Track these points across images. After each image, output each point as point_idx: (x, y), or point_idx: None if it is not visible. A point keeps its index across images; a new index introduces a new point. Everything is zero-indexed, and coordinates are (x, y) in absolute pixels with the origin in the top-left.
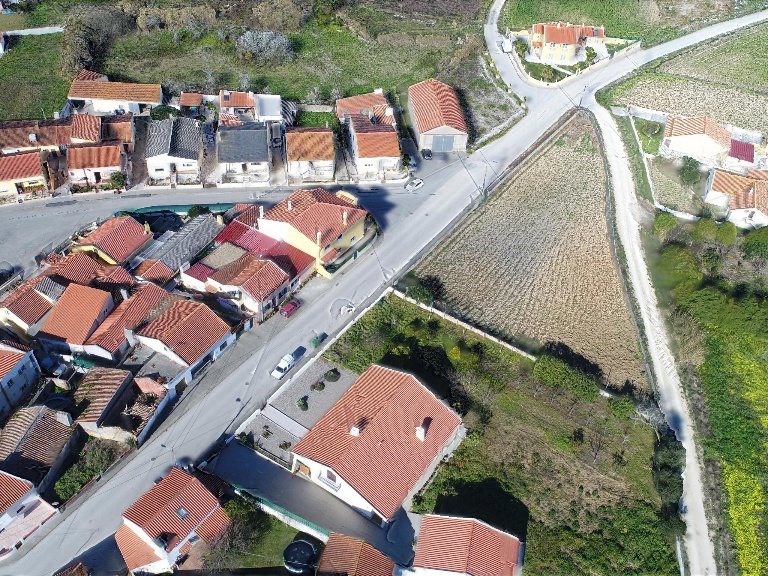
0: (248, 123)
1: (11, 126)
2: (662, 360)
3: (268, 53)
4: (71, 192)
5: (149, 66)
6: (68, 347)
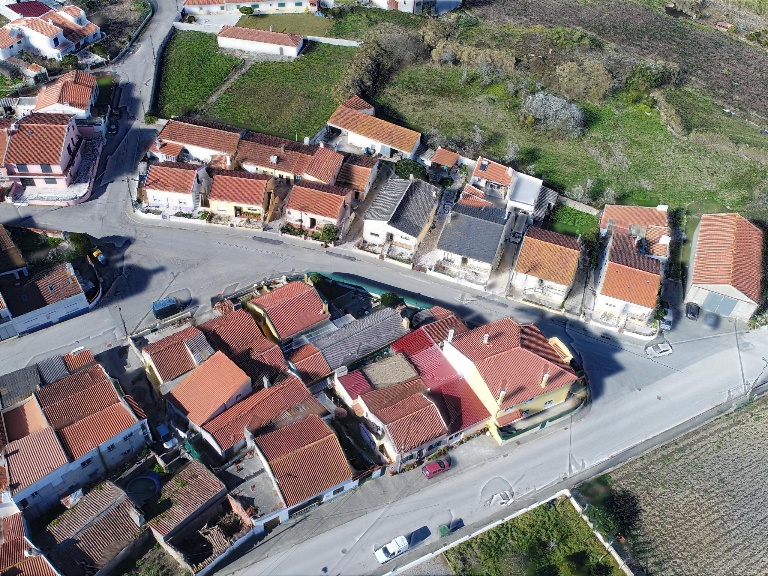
0: (490, 208)
1: (262, 140)
2: None
3: (552, 123)
4: (281, 231)
5: (423, 104)
6: (188, 422)
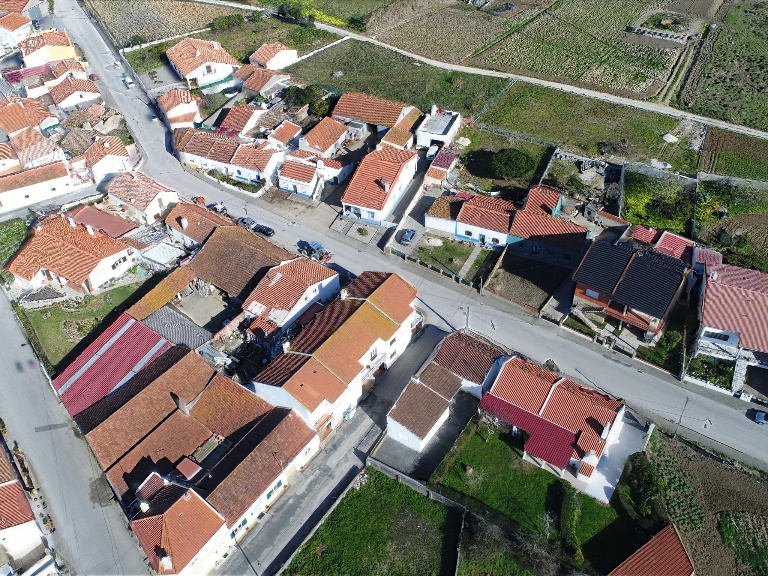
0: None
1: None
2: (246, 7)
3: None
4: None
5: None
6: None
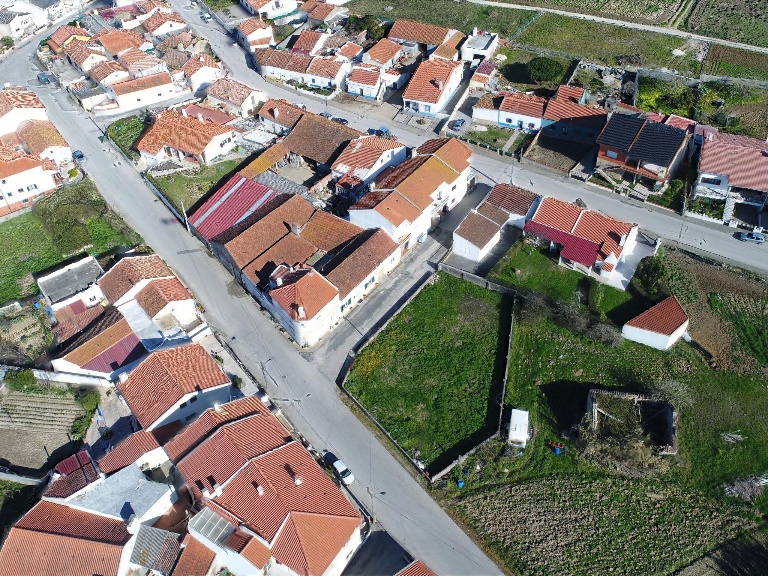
0: None
1: None
2: None
3: None
4: None
5: None
6: None
